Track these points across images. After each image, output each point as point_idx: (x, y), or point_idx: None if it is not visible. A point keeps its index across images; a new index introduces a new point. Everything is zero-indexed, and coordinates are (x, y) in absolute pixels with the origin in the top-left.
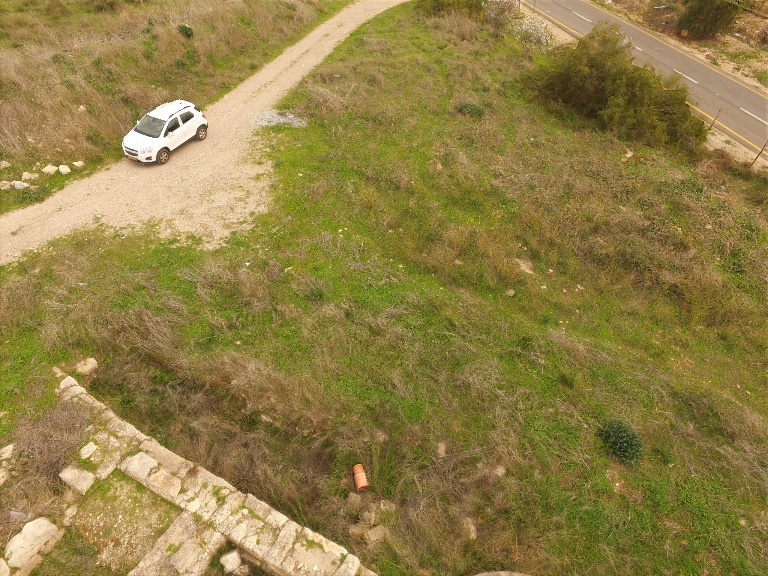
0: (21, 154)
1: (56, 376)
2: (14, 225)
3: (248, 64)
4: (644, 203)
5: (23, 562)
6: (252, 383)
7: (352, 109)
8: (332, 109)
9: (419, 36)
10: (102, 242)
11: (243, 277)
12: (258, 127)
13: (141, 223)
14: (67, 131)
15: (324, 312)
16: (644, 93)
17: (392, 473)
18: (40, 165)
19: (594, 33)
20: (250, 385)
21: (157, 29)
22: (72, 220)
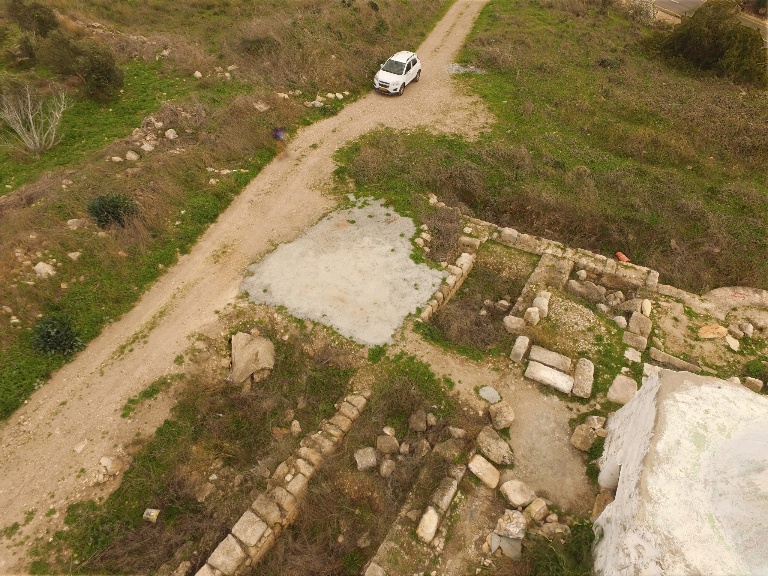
0: (307, 86)
1: (424, 198)
2: (330, 127)
3: (419, 32)
4: (767, 120)
5: (464, 272)
6: (550, 202)
7: (517, 63)
8: (506, 61)
9: (540, 13)
10: (397, 136)
11: (515, 150)
12: (452, 74)
13: (414, 127)
14: (333, 71)
15: (578, 168)
16: (753, 48)
17: (645, 254)
18: (320, 94)
19: (710, 2)
20: (549, 203)
21: (357, 4)
22: (365, 125)
